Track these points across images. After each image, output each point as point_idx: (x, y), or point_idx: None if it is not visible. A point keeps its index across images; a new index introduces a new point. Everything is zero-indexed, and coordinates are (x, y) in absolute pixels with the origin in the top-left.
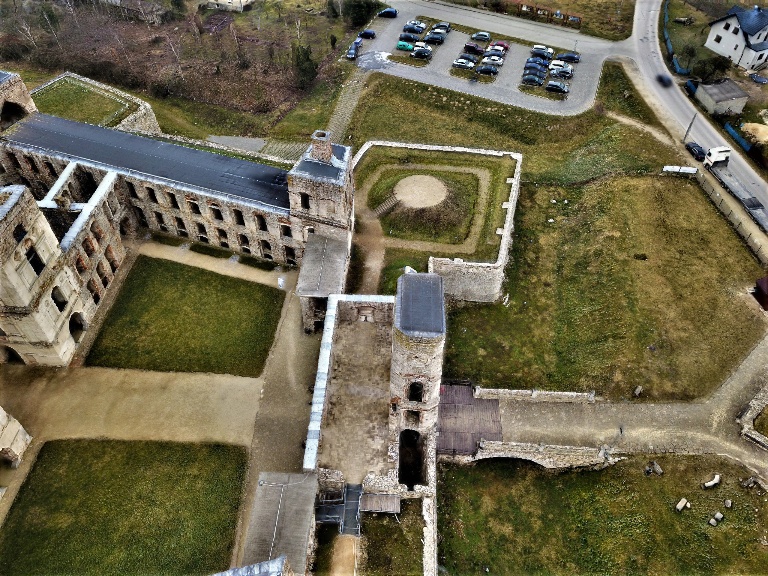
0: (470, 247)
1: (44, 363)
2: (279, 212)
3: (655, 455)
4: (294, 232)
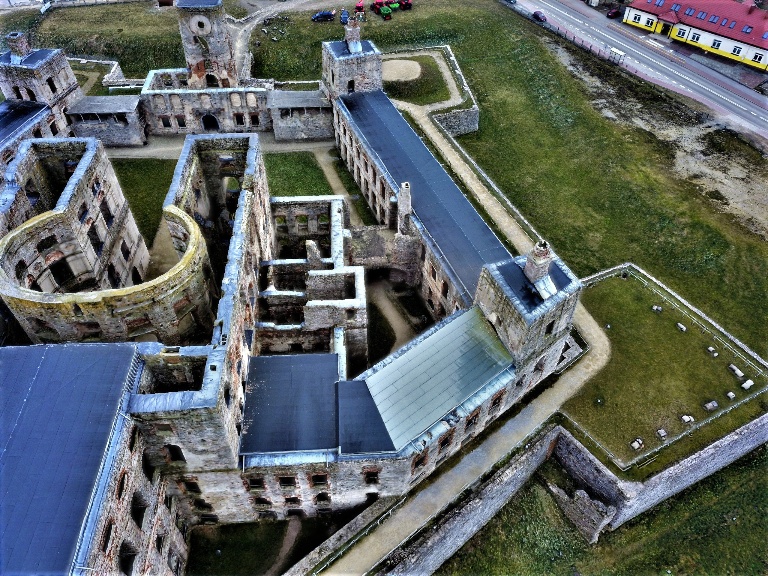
0: (94, 74)
1: (145, 267)
2: (44, 114)
3: (250, 44)
4: (59, 123)
